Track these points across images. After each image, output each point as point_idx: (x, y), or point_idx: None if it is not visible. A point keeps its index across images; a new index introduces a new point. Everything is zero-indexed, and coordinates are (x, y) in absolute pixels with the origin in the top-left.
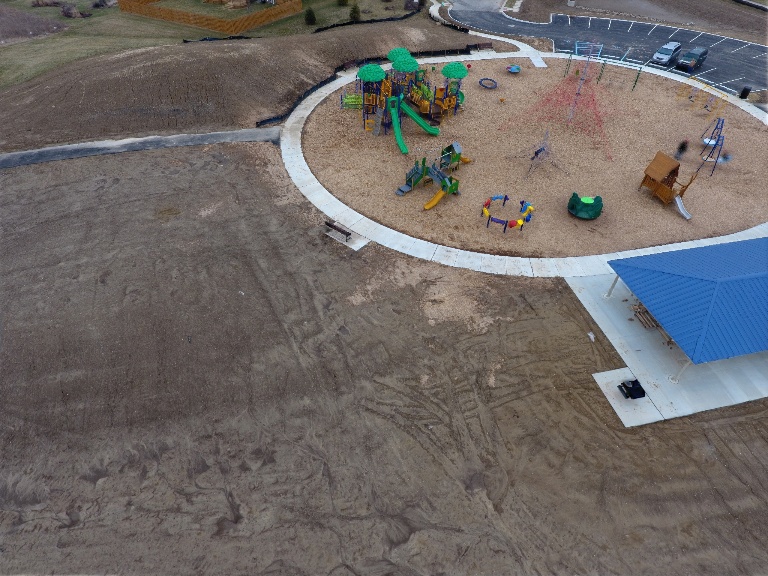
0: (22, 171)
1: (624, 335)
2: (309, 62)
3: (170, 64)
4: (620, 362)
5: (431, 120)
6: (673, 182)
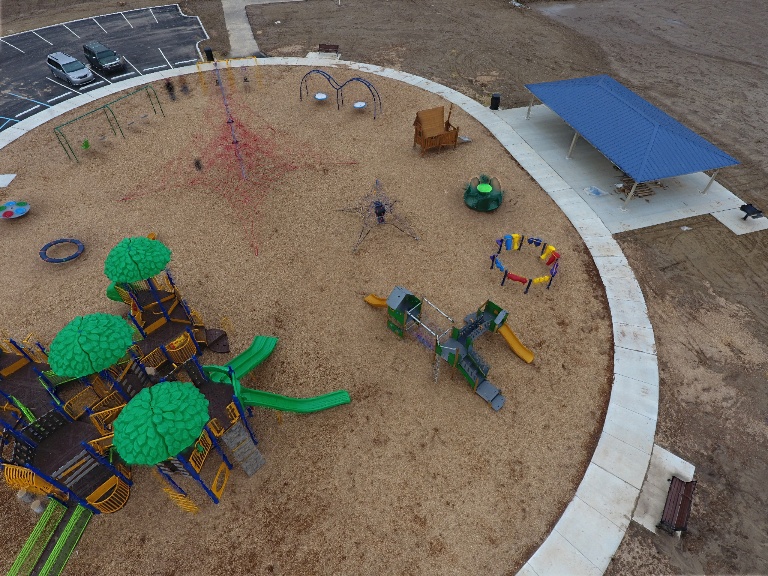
0: None
1: (672, 208)
2: None
3: None
4: (708, 216)
5: (202, 351)
6: None
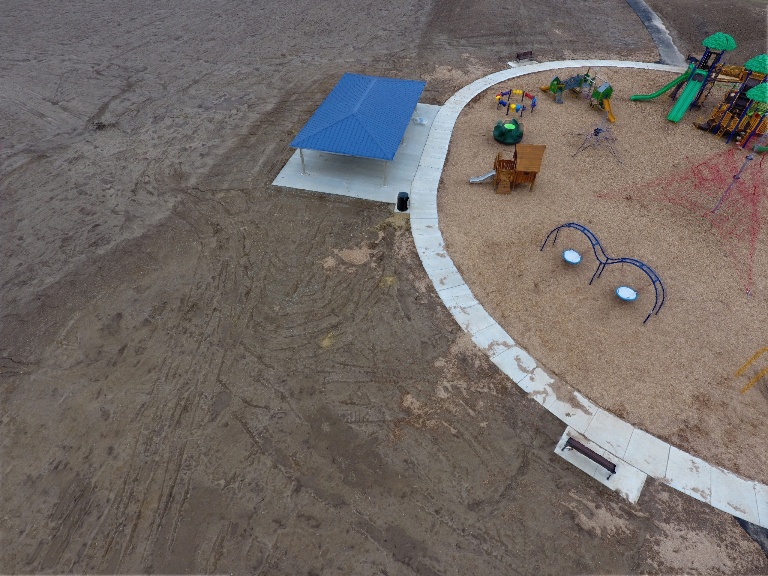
0: (626, 9)
1: None
2: None
3: None
4: None
5: None
6: (514, 172)
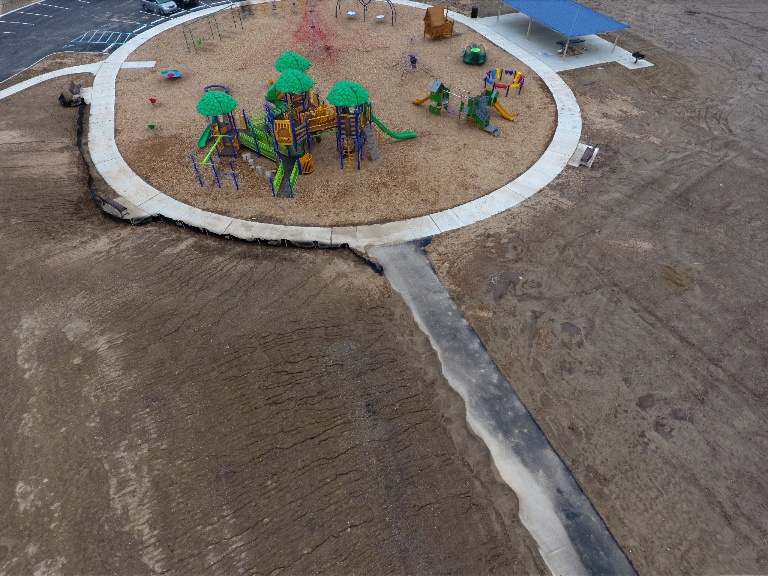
0: None
1: None
2: (103, 248)
3: (168, 476)
4: (614, 62)
5: None
6: None
